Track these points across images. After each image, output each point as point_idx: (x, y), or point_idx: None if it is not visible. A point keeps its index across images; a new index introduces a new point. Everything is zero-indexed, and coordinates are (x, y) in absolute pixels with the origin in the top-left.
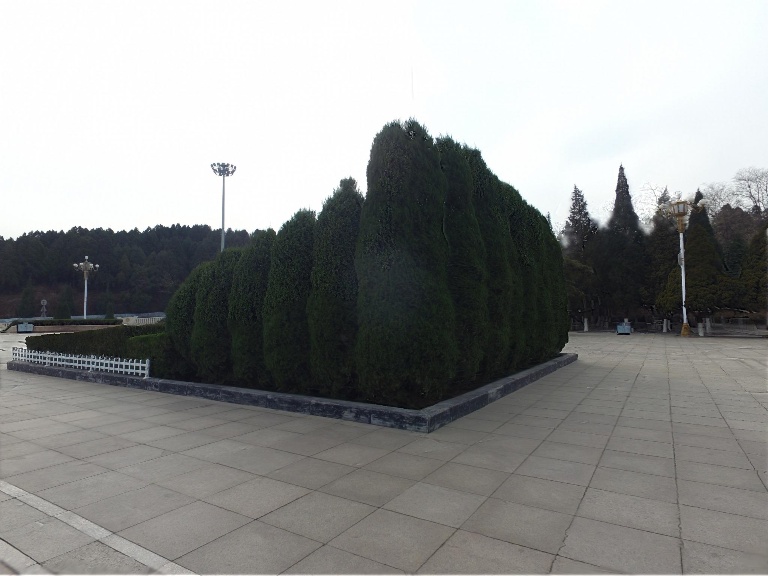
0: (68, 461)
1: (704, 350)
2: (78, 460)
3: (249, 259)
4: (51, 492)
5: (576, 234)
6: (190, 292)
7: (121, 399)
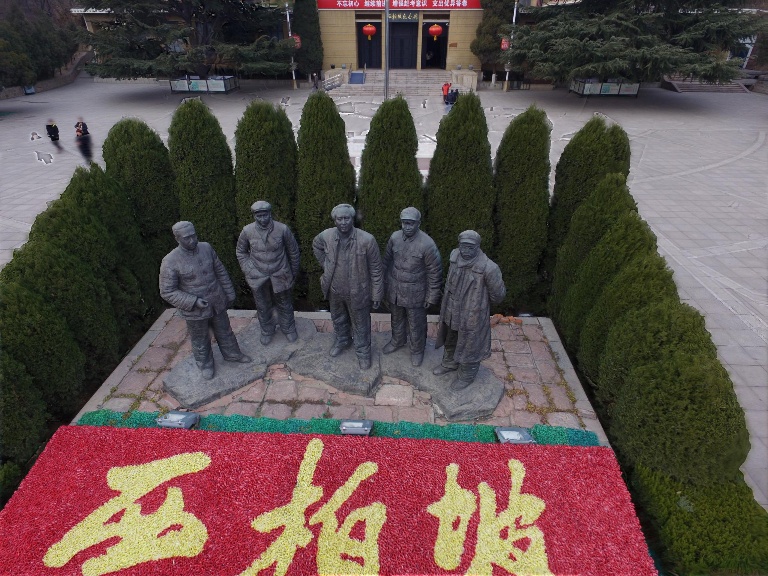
0: (766, 366)
1: (4, 222)
2: (761, 365)
3: None
4: (763, 343)
5: None
6: None
7: (759, 492)
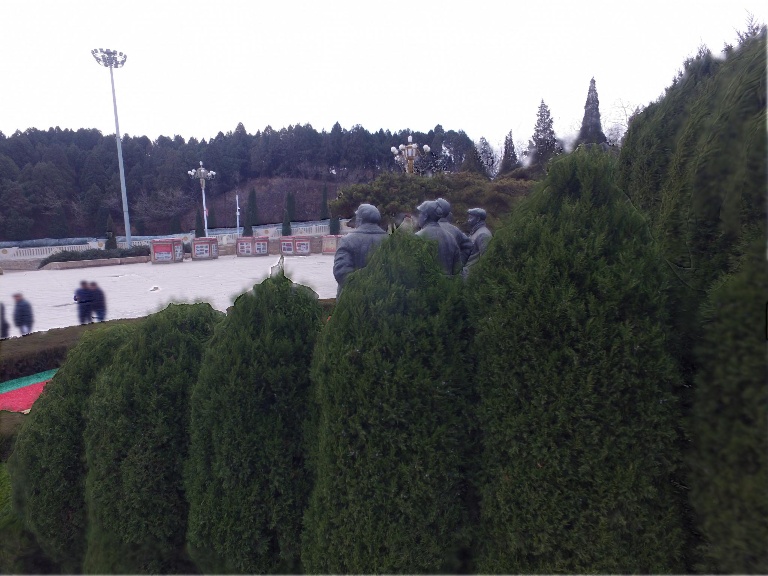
0: None
1: None
2: None
3: (241, 382)
4: None
5: (541, 156)
6: (68, 425)
7: None
